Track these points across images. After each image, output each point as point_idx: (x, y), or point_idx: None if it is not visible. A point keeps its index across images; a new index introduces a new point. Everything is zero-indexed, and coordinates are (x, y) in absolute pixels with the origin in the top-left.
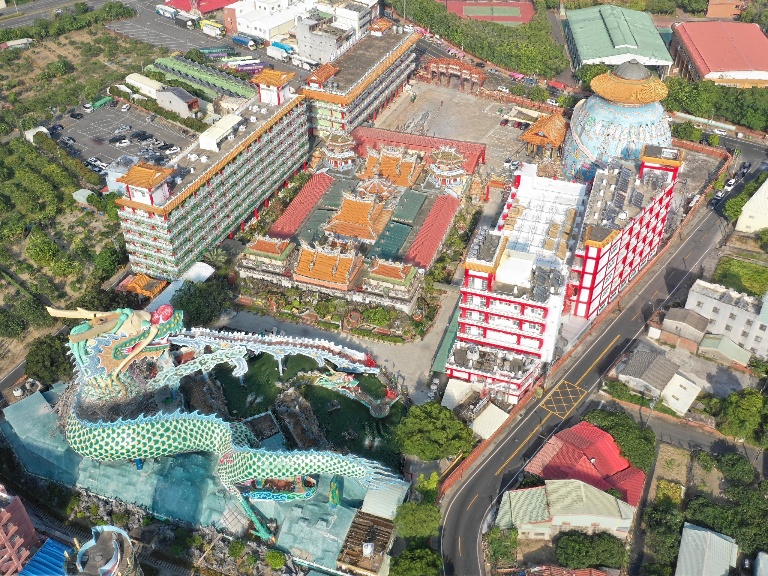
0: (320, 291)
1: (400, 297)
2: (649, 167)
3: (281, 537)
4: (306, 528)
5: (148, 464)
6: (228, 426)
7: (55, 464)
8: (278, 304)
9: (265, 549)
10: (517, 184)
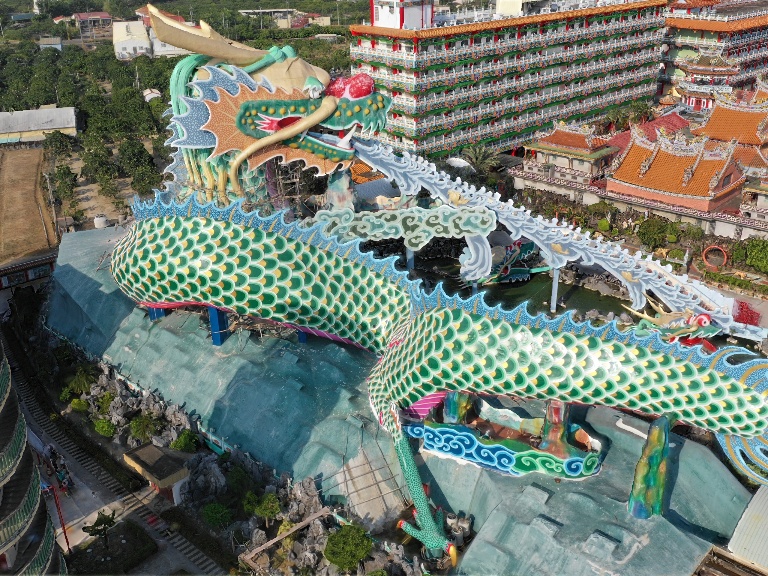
0: None
1: None
2: None
3: (473, 551)
4: (550, 542)
5: (236, 338)
6: (416, 289)
7: (83, 310)
8: None
9: (423, 573)
10: None
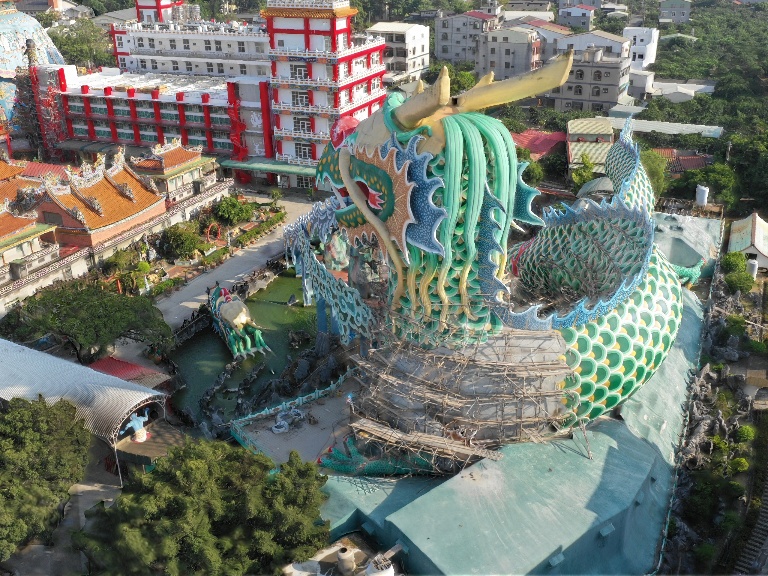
0: (134, 242)
1: (210, 186)
2: (165, 7)
3: (701, 253)
4: None
5: None
6: None
7: None
8: (125, 289)
9: None
10: (63, 84)
